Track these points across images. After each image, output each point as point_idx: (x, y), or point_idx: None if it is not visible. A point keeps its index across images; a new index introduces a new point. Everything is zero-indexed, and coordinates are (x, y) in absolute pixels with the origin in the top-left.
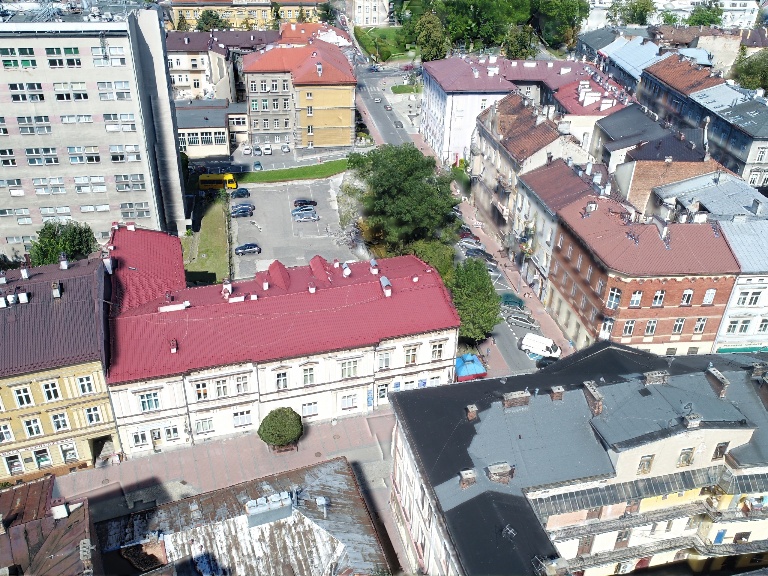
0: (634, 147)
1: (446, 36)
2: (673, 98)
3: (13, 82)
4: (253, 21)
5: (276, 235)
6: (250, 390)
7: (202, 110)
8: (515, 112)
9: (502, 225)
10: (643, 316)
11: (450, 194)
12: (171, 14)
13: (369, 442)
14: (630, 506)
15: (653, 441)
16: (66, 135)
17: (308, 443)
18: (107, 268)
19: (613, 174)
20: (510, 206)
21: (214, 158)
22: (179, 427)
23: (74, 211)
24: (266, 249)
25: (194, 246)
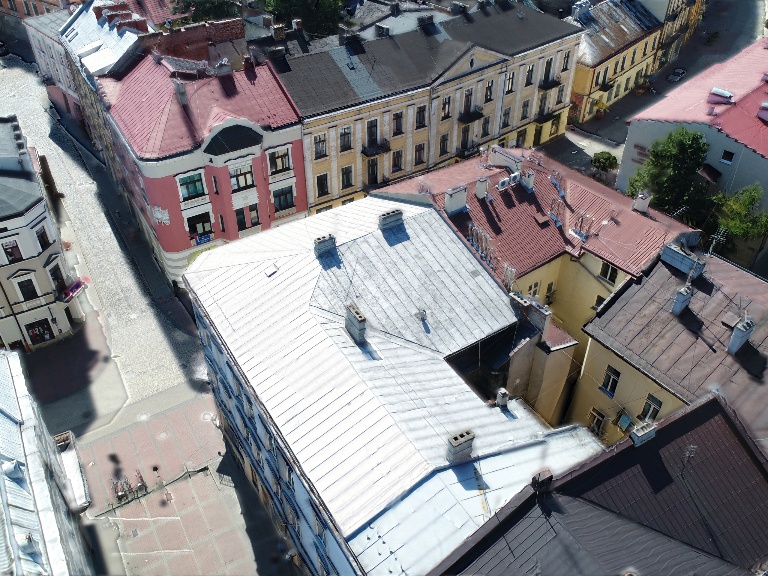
0: None
1: None
2: None
3: None
4: None
5: None
6: None
7: None
8: None
9: None
10: None
11: None
12: None
13: None
14: None
15: None
16: None
17: None
18: None
19: None
20: None
21: None
22: None
23: None
24: None
25: None
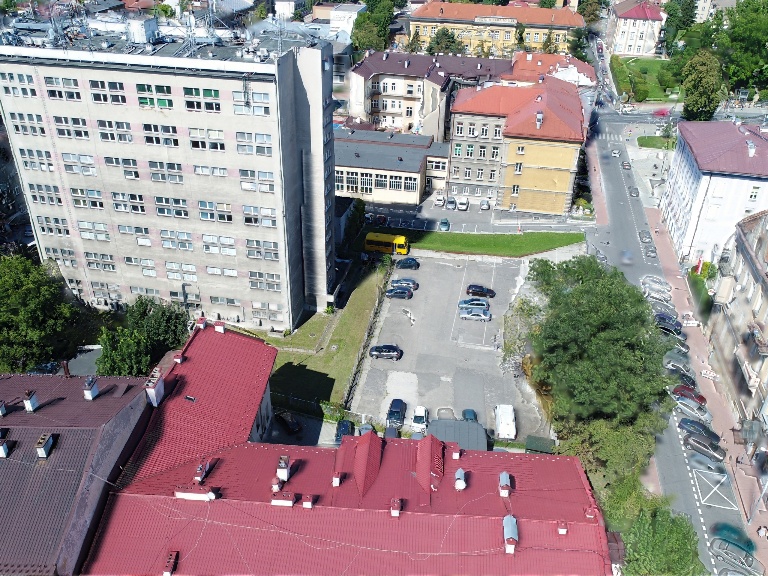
0: None
1: (723, 82)
2: None
3: (147, 122)
4: (489, 44)
5: (429, 334)
6: None
7: (400, 147)
8: None
9: (745, 393)
10: None
11: (659, 374)
12: None
13: None
14: None
15: None
16: (198, 187)
17: None
18: (151, 399)
19: None
20: (763, 375)
21: (400, 206)
22: None
23: (200, 271)
24: (409, 354)
25: (329, 329)
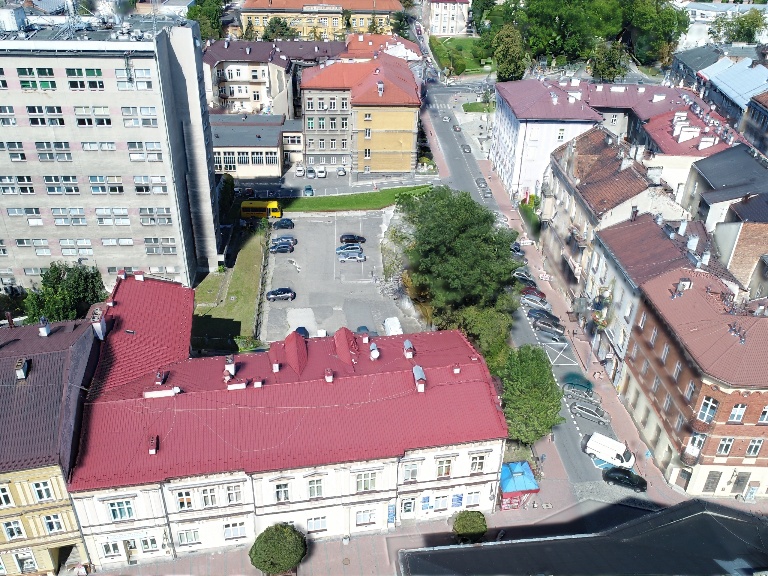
0: (739, 200)
1: (526, 51)
2: None
3: (31, 105)
4: (321, 30)
5: (315, 277)
6: (244, 500)
7: (256, 127)
8: (596, 151)
9: (573, 283)
10: (745, 434)
11: (509, 258)
12: (242, 19)
13: (385, 573)
14: None
15: None
16: (87, 163)
17: (311, 568)
18: (97, 333)
19: (712, 233)
20: (583, 263)
21: (264, 179)
22: (157, 538)
23: (95, 244)
24: (301, 294)
25: (225, 285)
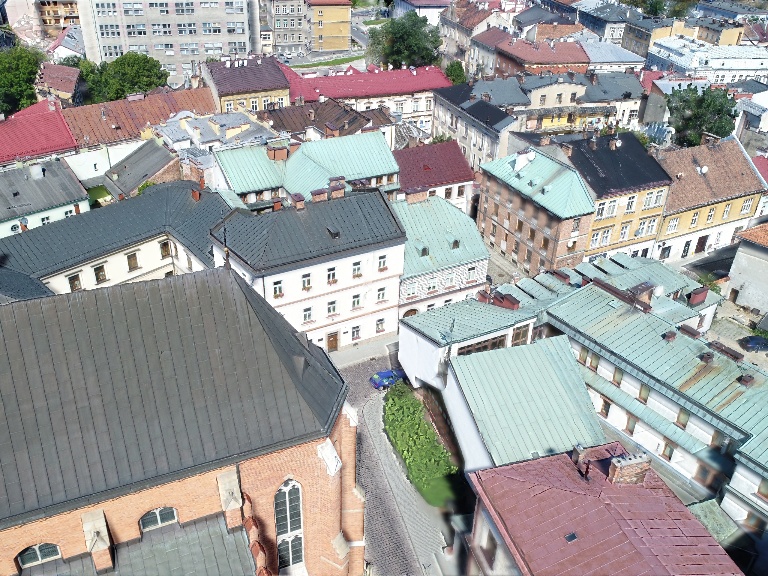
0: None
1: None
2: (562, 10)
3: None
4: None
5: None
6: None
7: None
8: (465, 7)
9: None
10: None
11: None
12: None
13: None
14: (538, 125)
15: (545, 86)
16: (203, 15)
17: None
18: None
19: (525, 37)
20: (466, 60)
21: None
22: None
23: None
24: None
25: None
